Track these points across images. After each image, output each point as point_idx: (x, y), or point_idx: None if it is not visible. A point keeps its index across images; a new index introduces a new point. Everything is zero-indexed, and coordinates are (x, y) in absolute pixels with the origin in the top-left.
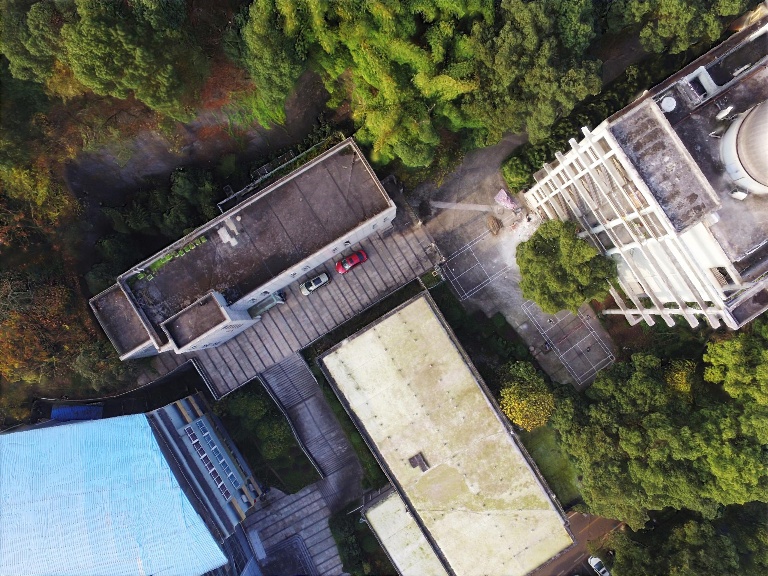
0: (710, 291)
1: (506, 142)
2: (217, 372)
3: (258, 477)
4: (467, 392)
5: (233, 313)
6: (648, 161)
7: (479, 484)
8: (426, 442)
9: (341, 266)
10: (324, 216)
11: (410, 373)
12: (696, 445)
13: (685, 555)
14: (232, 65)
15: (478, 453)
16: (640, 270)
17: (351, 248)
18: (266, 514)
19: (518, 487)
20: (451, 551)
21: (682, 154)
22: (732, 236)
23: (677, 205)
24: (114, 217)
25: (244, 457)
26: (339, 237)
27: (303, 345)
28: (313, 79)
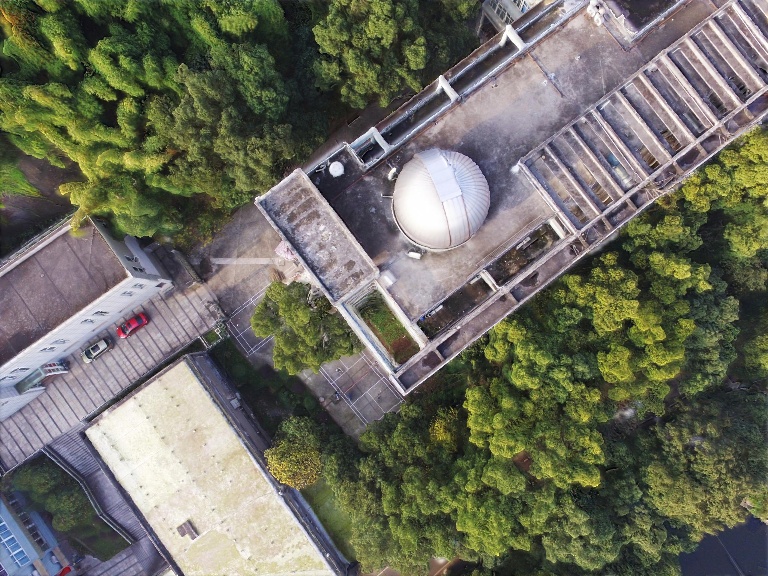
0: (377, 358)
1: None
2: (4, 447)
3: (72, 546)
4: (233, 455)
5: None
6: (303, 231)
7: (250, 548)
8: (194, 509)
9: (121, 331)
10: (66, 290)
11: (173, 440)
12: (443, 499)
13: None
14: None
15: (247, 517)
16: (400, 318)
17: (133, 311)
18: None
19: (290, 548)
20: None
21: (337, 222)
22: (412, 296)
23: (335, 274)
24: None
25: None
26: (77, 312)
27: None
28: None
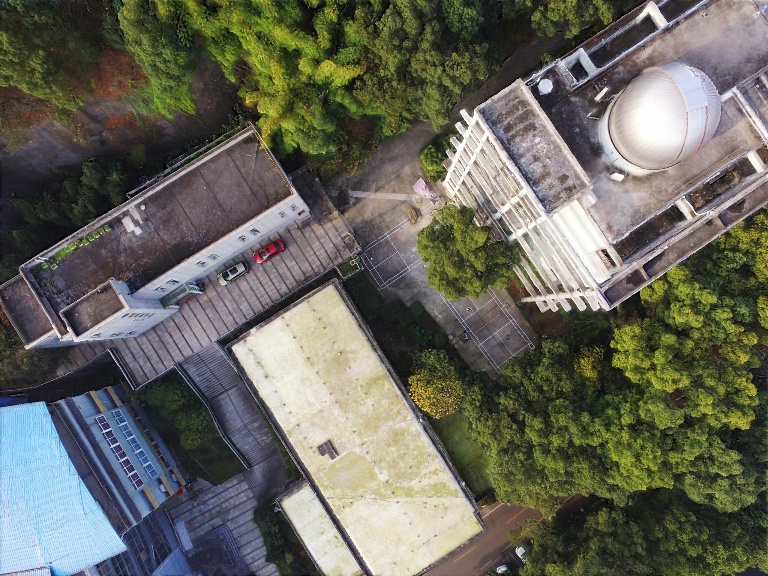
0: (583, 272)
1: (425, 131)
2: (136, 362)
3: (185, 468)
4: (376, 380)
5: (135, 301)
6: (519, 142)
7: (388, 472)
8: (335, 430)
9: (258, 256)
10: (228, 204)
11: (319, 361)
12: (596, 430)
13: (595, 542)
14: (129, 54)
15: (387, 441)
16: None
17: (269, 238)
18: (193, 505)
19: (427, 475)
20: (360, 539)
21: (553, 135)
22: (611, 218)
23: (548, 186)
24: (23, 207)
25: (171, 448)
26: (241, 225)
27: (221, 335)
28: (216, 68)
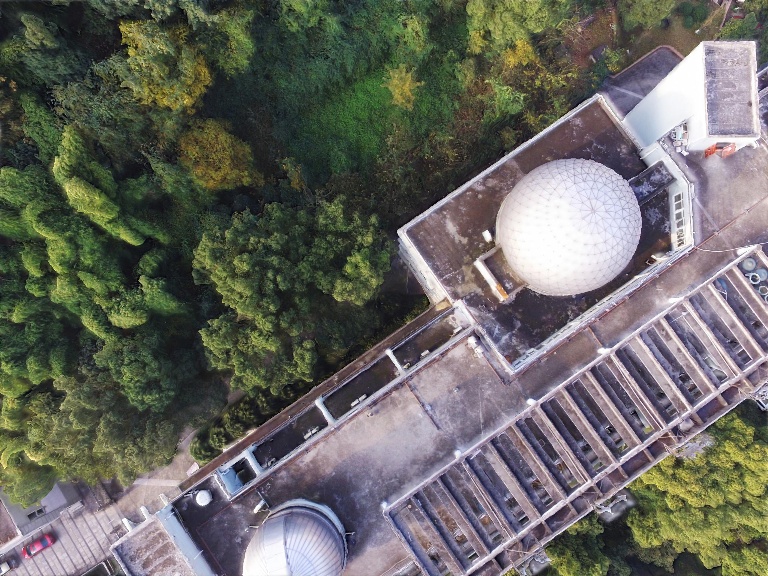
0: None
1: None
2: None
3: None
4: None
5: None
6: None
7: None
8: None
9: None
10: None
11: None
12: None
13: None
14: None
15: None
16: None
17: (41, 529)
18: None
19: None
20: None
21: None
22: None
23: None
24: None
25: None
26: None
27: None
28: None
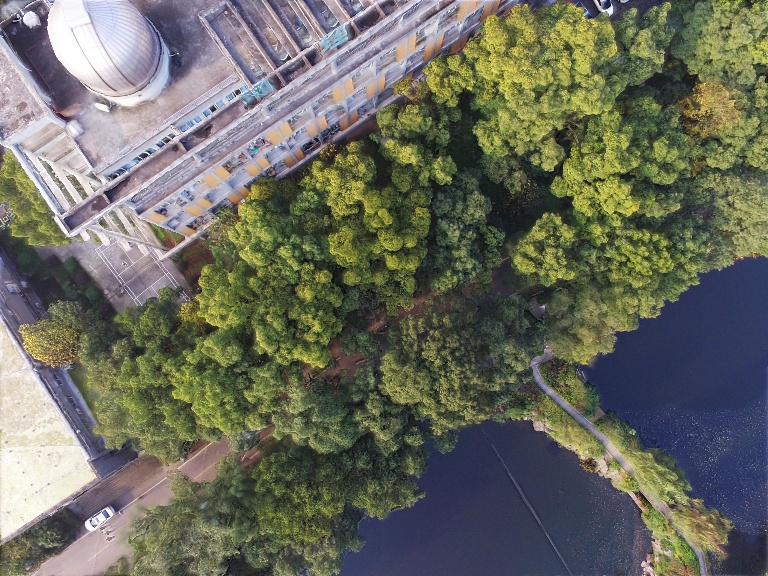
0: None
1: None
2: None
3: None
4: None
5: None
6: None
7: (2, 421)
8: None
9: None
10: None
11: None
12: (170, 371)
13: None
14: None
15: (1, 390)
16: None
17: None
18: None
19: (42, 423)
20: None
21: None
22: (100, 148)
23: (7, 114)
24: None
25: None
26: None
27: None
28: None
